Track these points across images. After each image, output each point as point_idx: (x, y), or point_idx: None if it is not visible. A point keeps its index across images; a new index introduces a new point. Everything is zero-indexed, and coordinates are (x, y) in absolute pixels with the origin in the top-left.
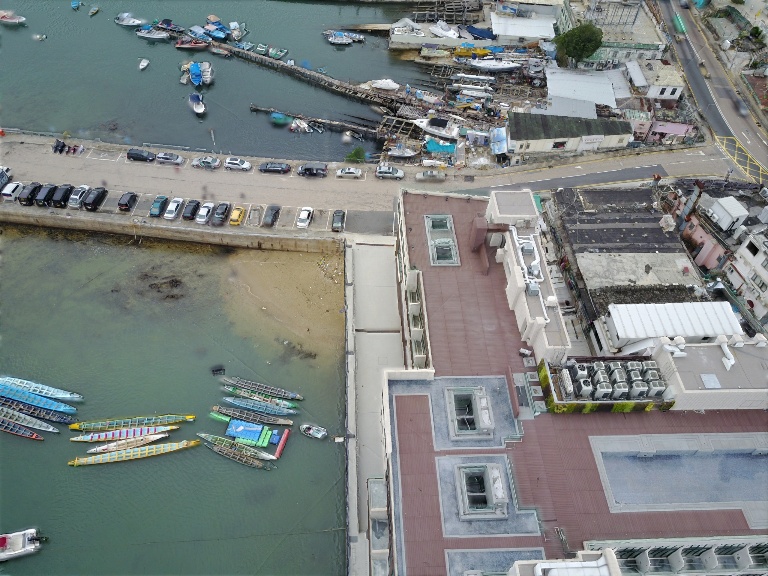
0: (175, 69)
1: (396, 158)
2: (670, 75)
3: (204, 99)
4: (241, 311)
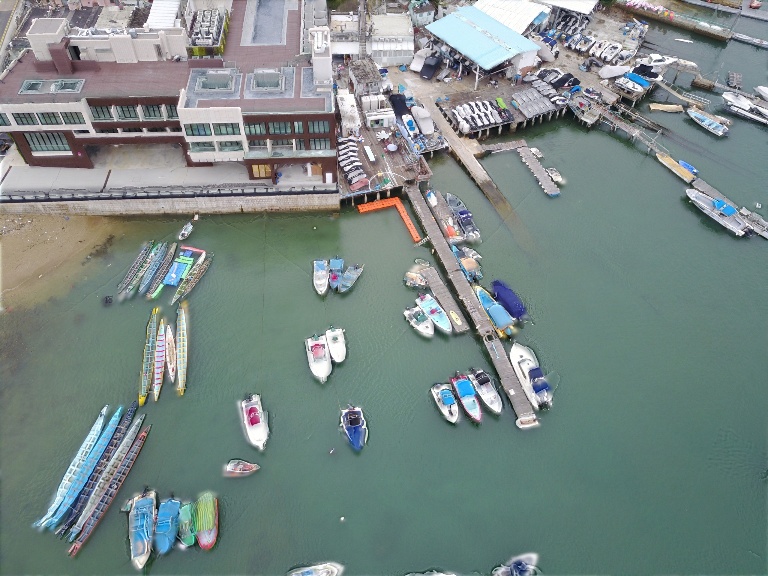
0: None
1: None
2: None
3: None
4: (37, 293)
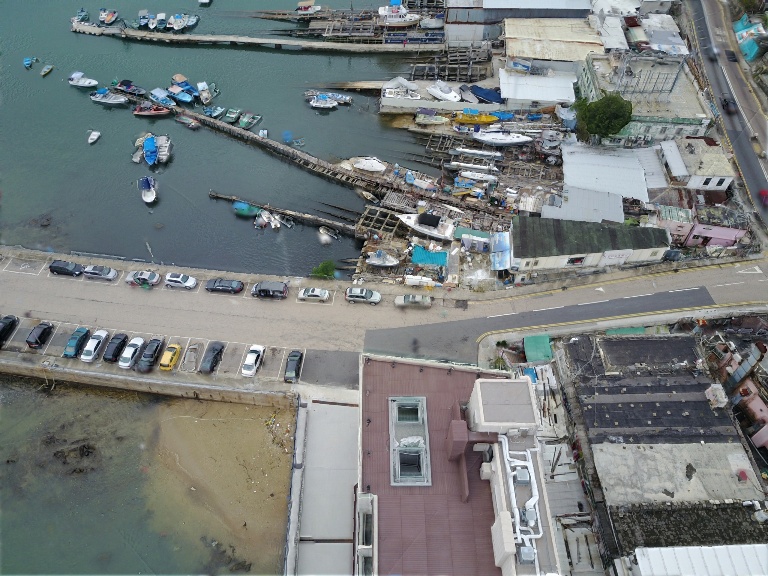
0: (128, 144)
1: (375, 267)
2: (716, 161)
3: (157, 183)
4: (164, 493)
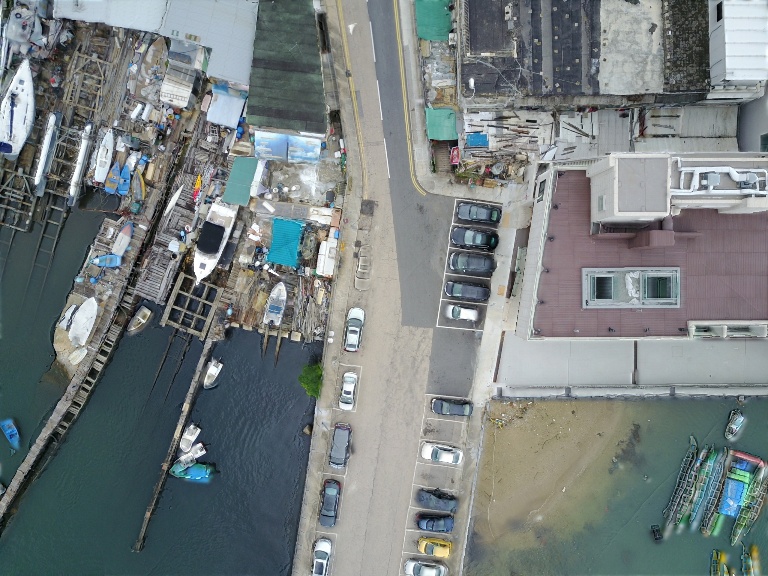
0: None
1: (284, 312)
2: None
3: None
4: (568, 517)
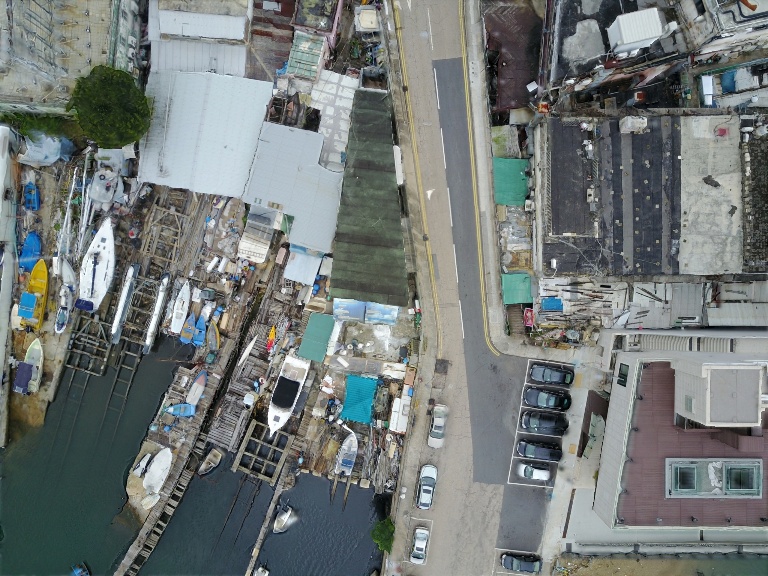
0: None
1: None
2: None
3: None
4: None
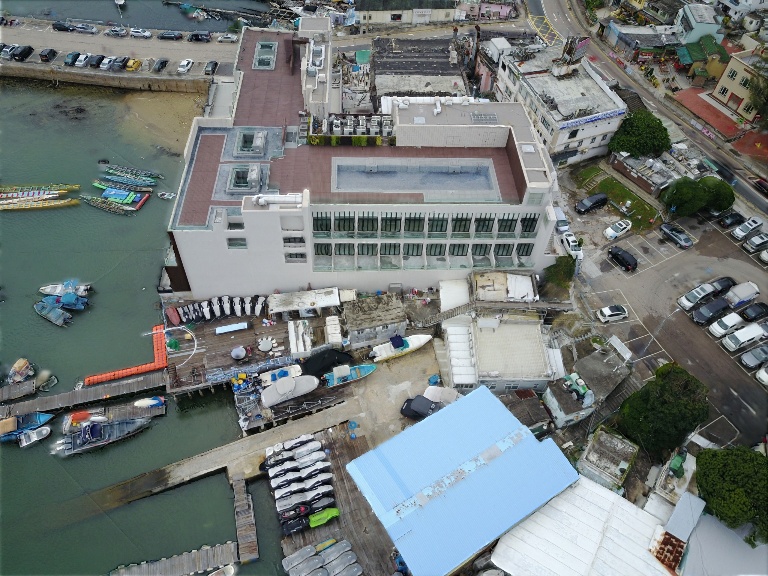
0: None
1: None
2: None
3: None
4: (128, 128)
